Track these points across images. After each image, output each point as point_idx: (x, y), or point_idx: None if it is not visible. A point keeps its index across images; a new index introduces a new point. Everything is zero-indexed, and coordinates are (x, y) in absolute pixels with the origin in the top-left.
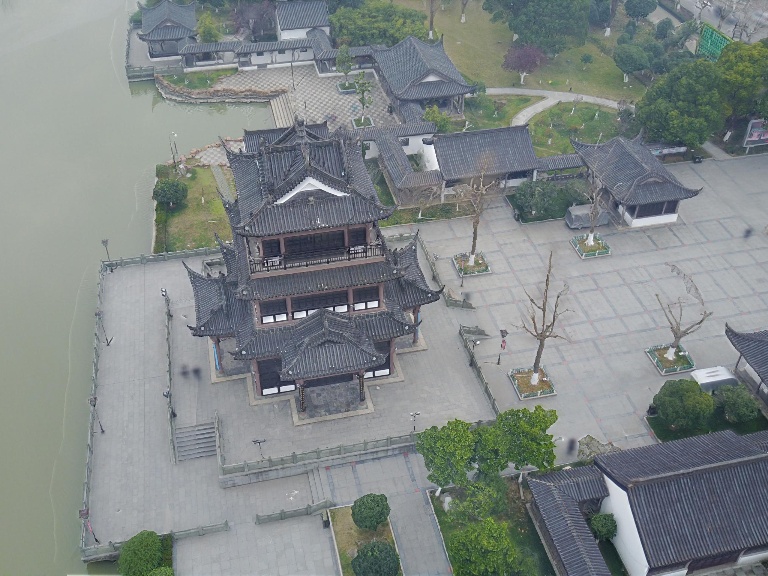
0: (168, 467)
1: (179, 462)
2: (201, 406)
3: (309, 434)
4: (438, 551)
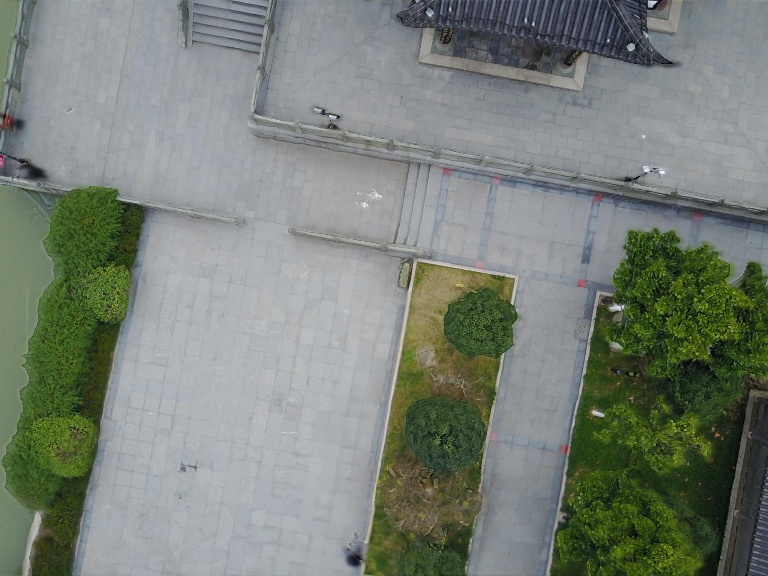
0: (171, 47)
1: (192, 44)
2: None
3: (438, 92)
4: (562, 411)
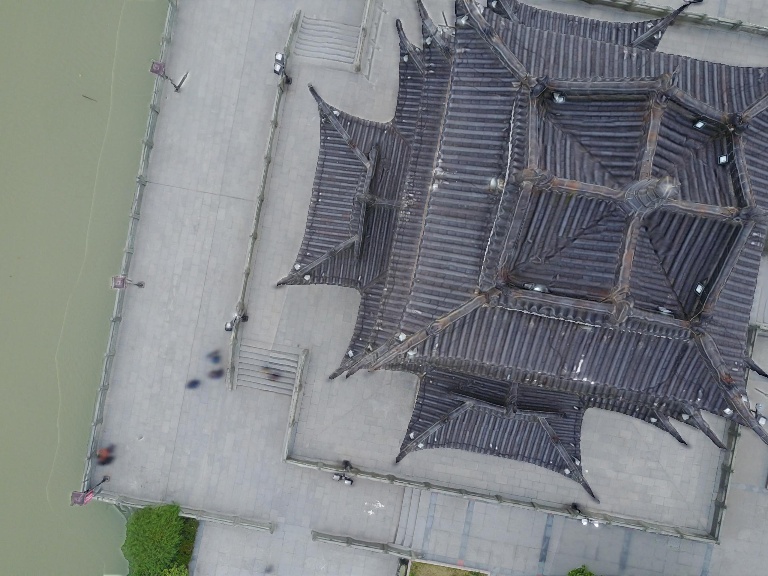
0: (220, 389)
1: (237, 387)
2: (288, 315)
3: None
4: None
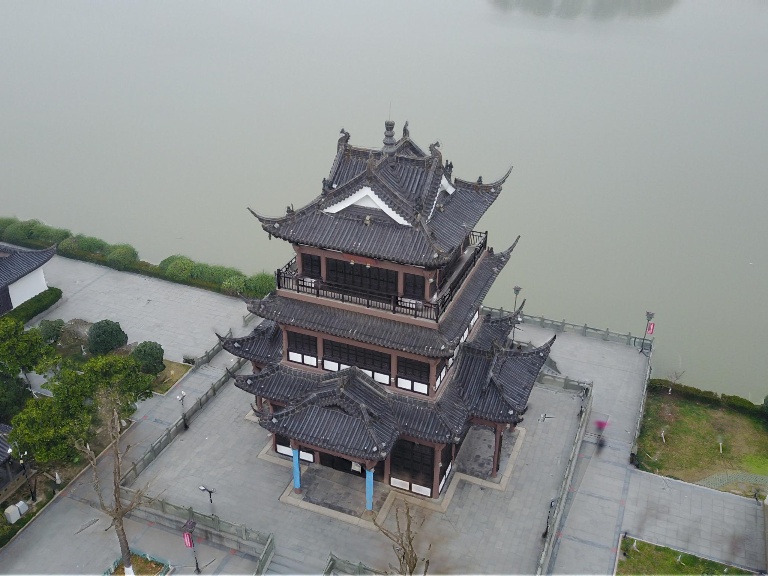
0: None
1: None
2: None
3: None
4: None
